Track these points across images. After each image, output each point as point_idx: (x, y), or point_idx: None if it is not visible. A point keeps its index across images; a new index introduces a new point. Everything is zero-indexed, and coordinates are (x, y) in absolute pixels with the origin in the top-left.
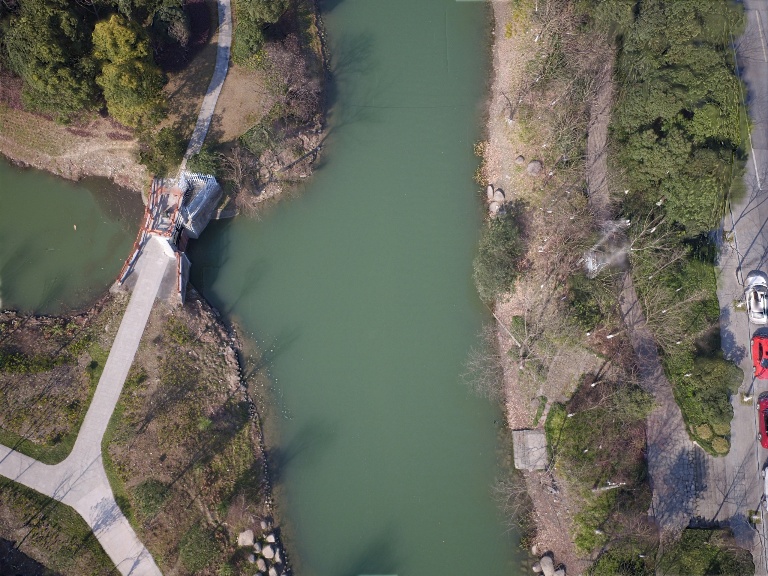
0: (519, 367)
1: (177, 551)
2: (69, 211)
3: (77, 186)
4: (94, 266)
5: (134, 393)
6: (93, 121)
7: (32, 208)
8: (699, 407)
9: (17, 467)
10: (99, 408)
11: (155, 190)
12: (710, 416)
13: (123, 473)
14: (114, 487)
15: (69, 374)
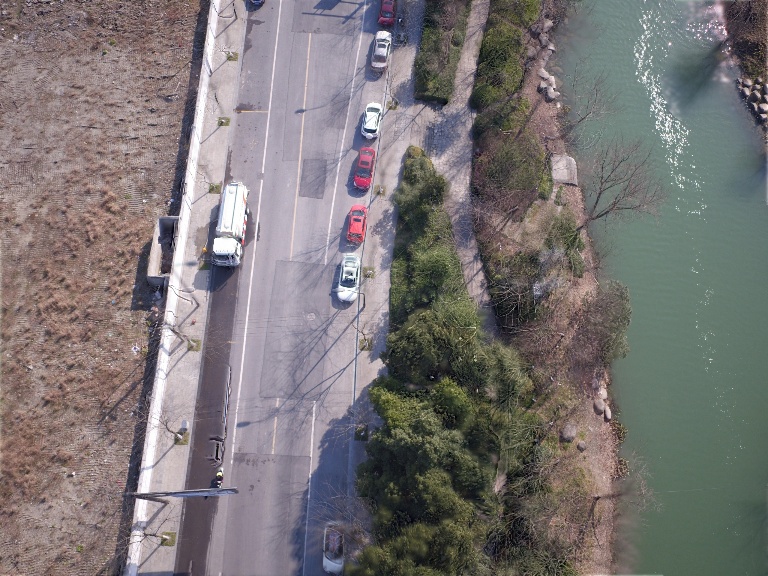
0: None
1: None
2: None
3: None
4: None
5: None
6: None
7: None
8: None
9: None
10: None
11: None
12: None
13: None
14: None
15: None
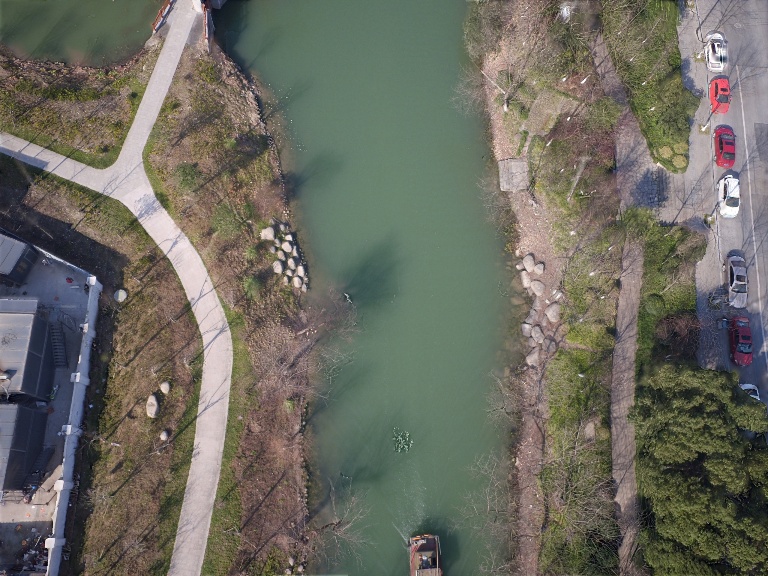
0: (504, 108)
1: (209, 235)
2: None
3: None
4: (130, 29)
5: (169, 116)
6: None
7: None
8: (661, 133)
9: (71, 170)
10: (140, 127)
11: None
12: (670, 135)
13: (162, 175)
14: (154, 186)
15: (113, 102)
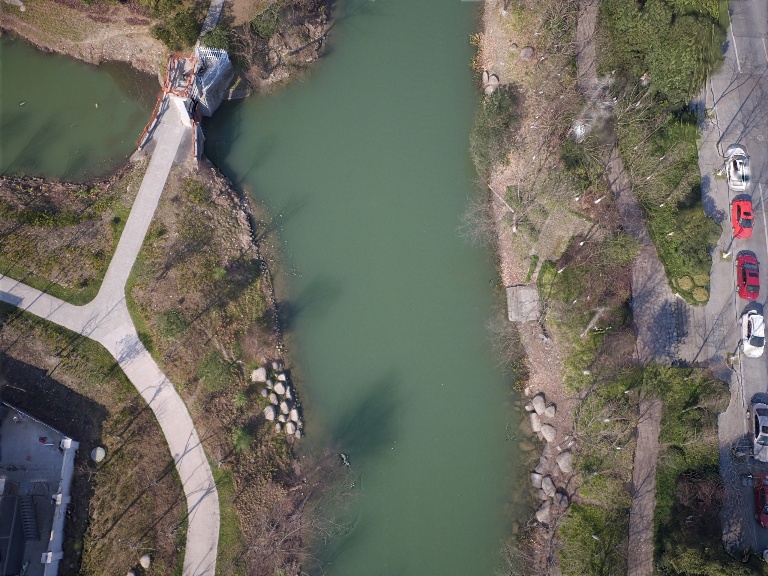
0: (512, 229)
1: (196, 381)
2: (91, 91)
3: (98, 69)
4: (115, 140)
5: (154, 245)
6: (112, 8)
7: (56, 88)
8: (681, 262)
9: (48, 307)
10: (122, 257)
11: (171, 68)
12: (691, 267)
13: (145, 313)
14: (137, 325)
15: (94, 228)
